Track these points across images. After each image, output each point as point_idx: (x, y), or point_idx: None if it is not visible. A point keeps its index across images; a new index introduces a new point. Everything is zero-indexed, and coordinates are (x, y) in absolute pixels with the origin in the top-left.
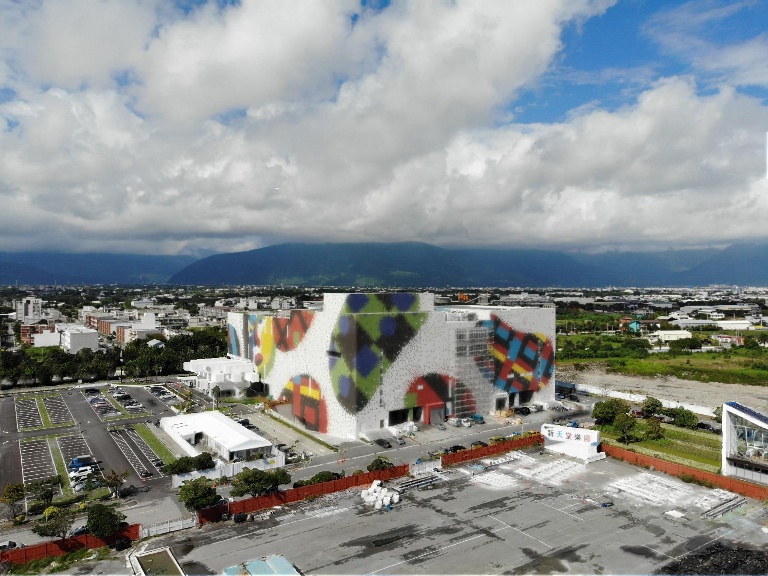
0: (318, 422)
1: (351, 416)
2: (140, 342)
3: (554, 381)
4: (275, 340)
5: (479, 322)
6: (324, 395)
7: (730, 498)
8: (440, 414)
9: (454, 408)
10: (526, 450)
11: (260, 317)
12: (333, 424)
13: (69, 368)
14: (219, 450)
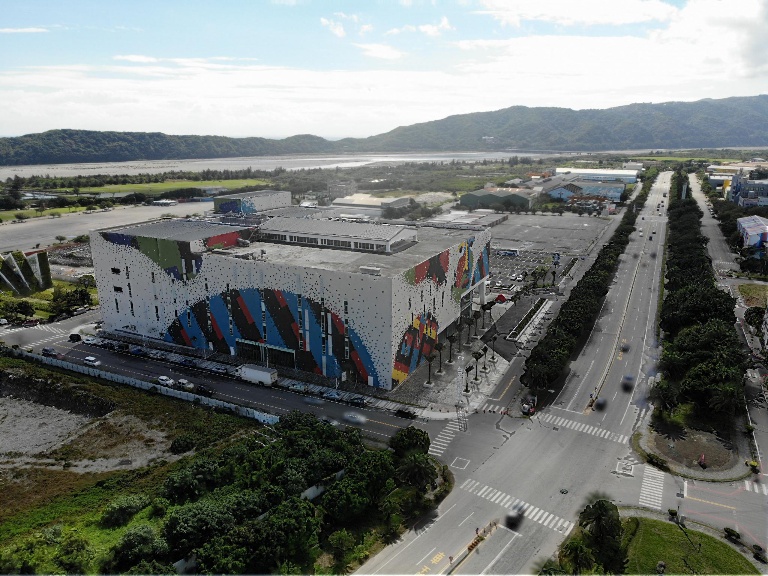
0: None
1: None
2: None
3: (102, 307)
4: None
5: None
6: None
7: (73, 276)
8: None
9: None
10: None
11: None
12: None
13: None
14: None
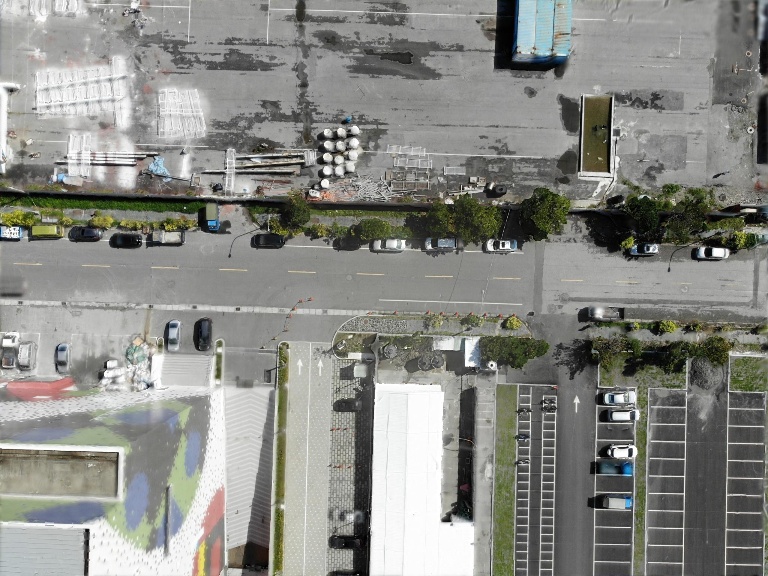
0: None
1: None
2: None
3: None
4: None
5: None
6: None
7: None
8: None
9: None
10: (40, 181)
11: None
12: None
13: None
14: None
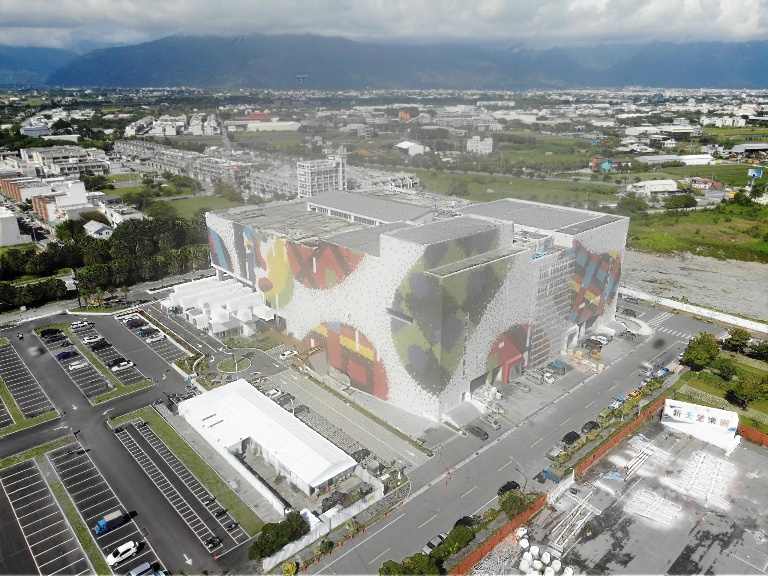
0: (372, 385)
1: (430, 395)
2: (74, 225)
3: (616, 299)
4: (292, 270)
5: (561, 253)
6: (382, 358)
7: None
8: (516, 367)
9: (530, 357)
10: (644, 430)
11: (264, 234)
12: (398, 395)
13: (4, 293)
14: (288, 474)
